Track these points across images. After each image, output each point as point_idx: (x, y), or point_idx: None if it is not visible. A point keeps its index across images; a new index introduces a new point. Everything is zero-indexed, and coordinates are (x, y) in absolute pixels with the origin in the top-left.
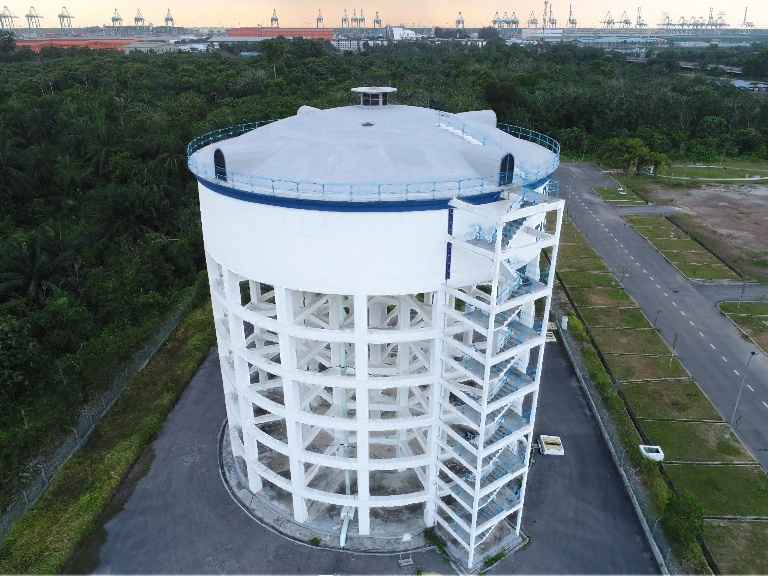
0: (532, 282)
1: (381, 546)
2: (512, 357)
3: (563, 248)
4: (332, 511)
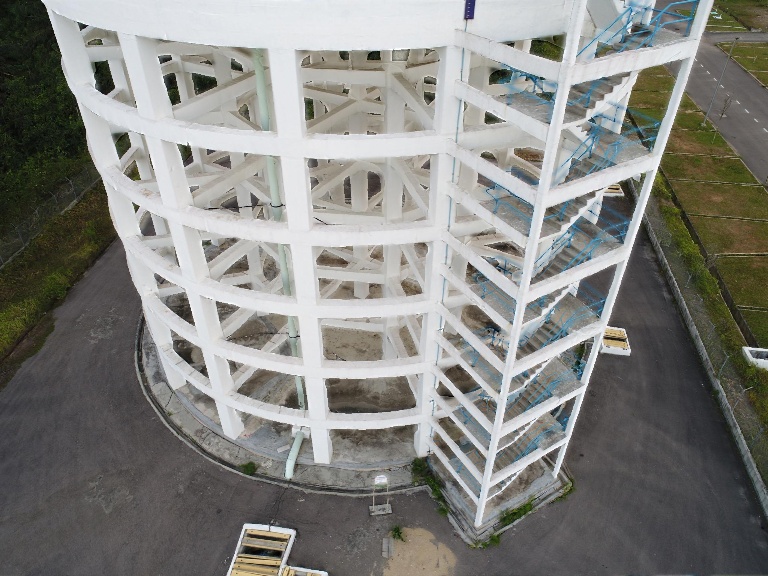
0: (653, 30)
1: (346, 481)
2: (590, 193)
3: (637, 80)
4: (281, 423)
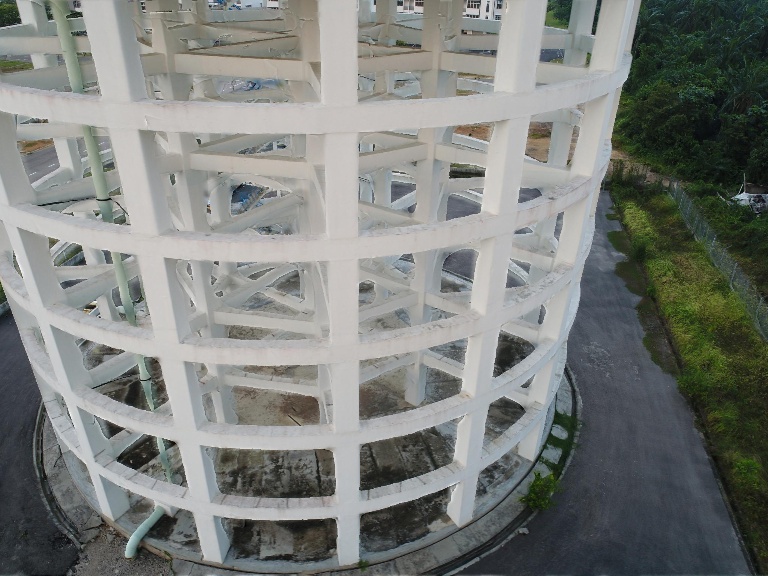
0: None
1: None
2: None
3: None
4: None
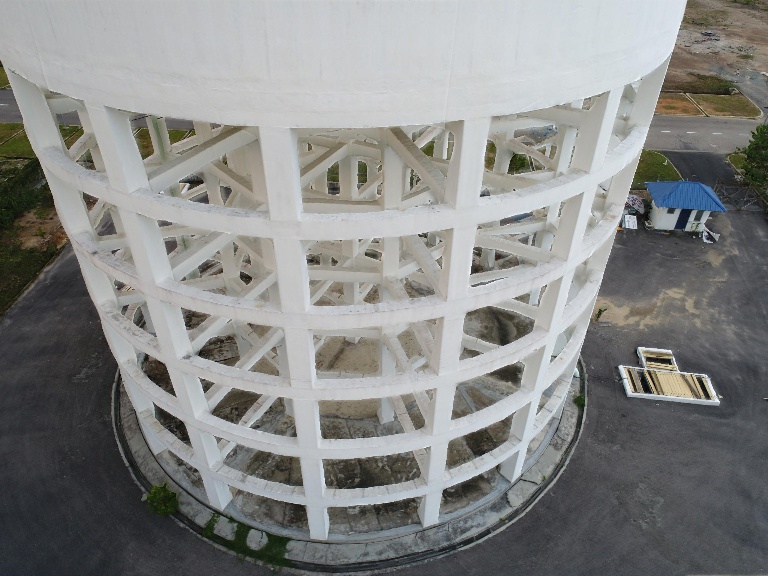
0: None
1: None
2: None
3: None
4: None
